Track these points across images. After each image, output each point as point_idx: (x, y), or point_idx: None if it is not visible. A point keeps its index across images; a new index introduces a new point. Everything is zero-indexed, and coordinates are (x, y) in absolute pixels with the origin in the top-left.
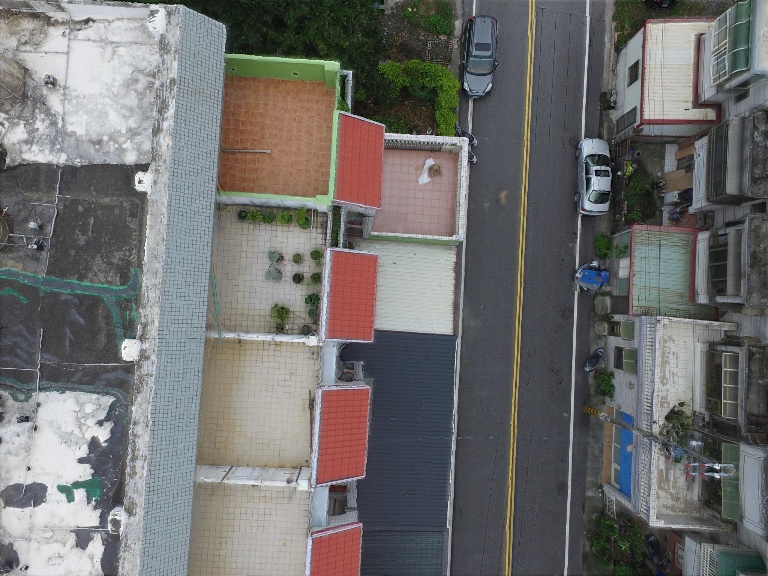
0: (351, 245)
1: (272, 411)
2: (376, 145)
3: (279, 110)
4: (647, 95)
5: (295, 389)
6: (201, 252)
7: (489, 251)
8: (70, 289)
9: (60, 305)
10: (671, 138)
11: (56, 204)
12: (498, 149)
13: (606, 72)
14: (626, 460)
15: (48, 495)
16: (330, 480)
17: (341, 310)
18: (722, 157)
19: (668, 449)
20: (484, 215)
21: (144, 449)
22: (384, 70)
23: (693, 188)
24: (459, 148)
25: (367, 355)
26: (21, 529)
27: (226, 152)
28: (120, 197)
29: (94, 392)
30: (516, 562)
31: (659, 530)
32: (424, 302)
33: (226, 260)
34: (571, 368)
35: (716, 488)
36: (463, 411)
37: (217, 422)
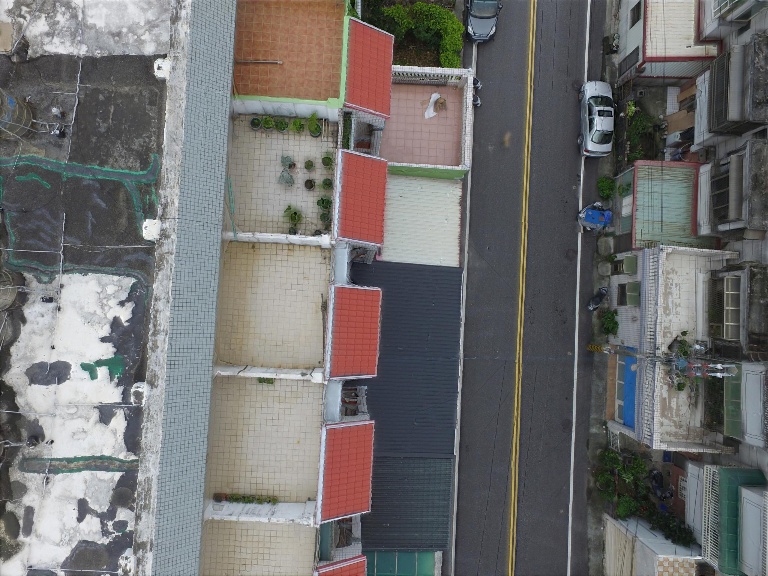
0: None
1: (285, 314)
2: (385, 54)
3: (290, 23)
4: (649, 33)
5: (308, 293)
6: (218, 141)
7: (494, 193)
8: (92, 174)
9: (82, 190)
10: (673, 79)
11: (77, 93)
12: (502, 93)
13: (608, 17)
14: (630, 393)
15: (72, 373)
16: (343, 375)
17: (353, 211)
18: (723, 86)
19: (671, 377)
20: (488, 158)
21: (165, 324)
22: (389, 12)
23: (695, 127)
24: (464, 81)
25: None
26: (46, 405)
27: (239, 63)
28: (139, 86)
29: (116, 274)
30: (522, 497)
31: (662, 465)
32: (431, 235)
33: (239, 168)
34: (575, 308)
35: (718, 409)
36: (469, 350)
37: (232, 324)
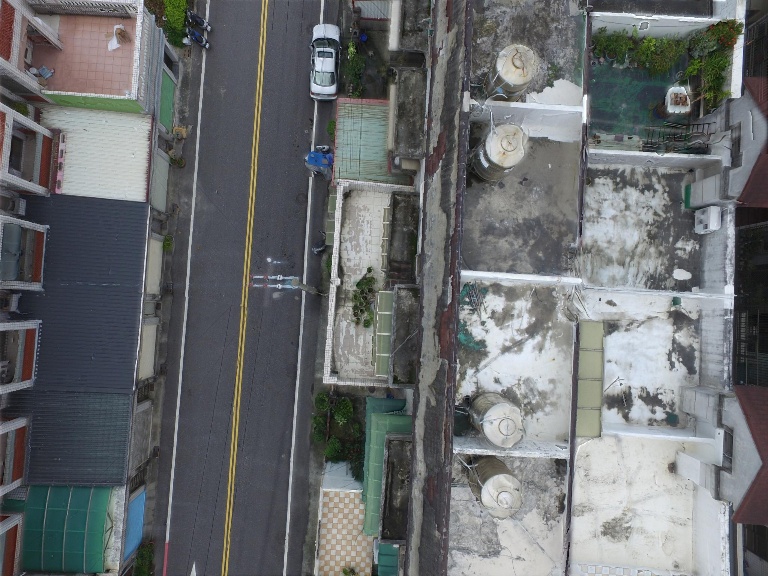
0: (38, 110)
1: None
2: None
3: None
4: None
5: None
6: None
7: (224, 137)
8: None
9: None
10: None
11: None
12: (235, 36)
13: None
14: None
15: None
16: None
17: None
18: None
19: (356, 314)
20: (220, 101)
21: None
22: None
23: None
24: None
25: (54, 219)
26: None
27: None
28: None
29: None
30: (242, 441)
31: None
32: (116, 169)
33: None
34: (303, 252)
35: None
36: (195, 294)
37: None
